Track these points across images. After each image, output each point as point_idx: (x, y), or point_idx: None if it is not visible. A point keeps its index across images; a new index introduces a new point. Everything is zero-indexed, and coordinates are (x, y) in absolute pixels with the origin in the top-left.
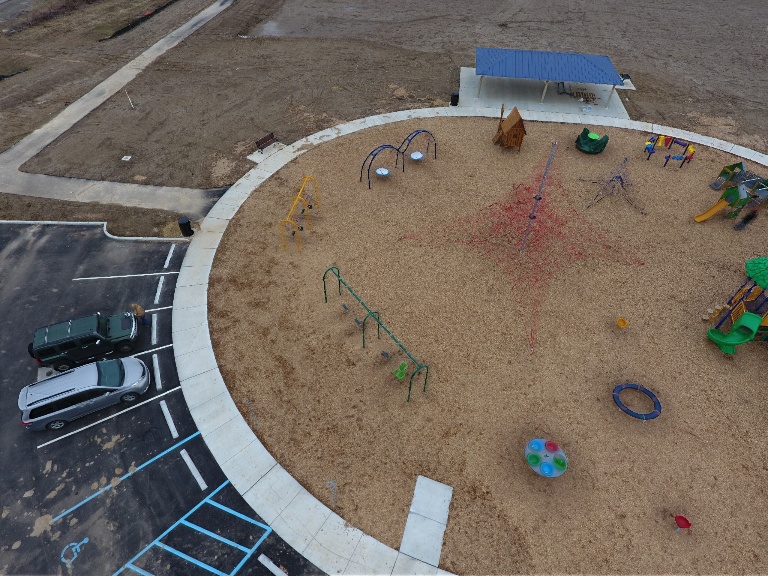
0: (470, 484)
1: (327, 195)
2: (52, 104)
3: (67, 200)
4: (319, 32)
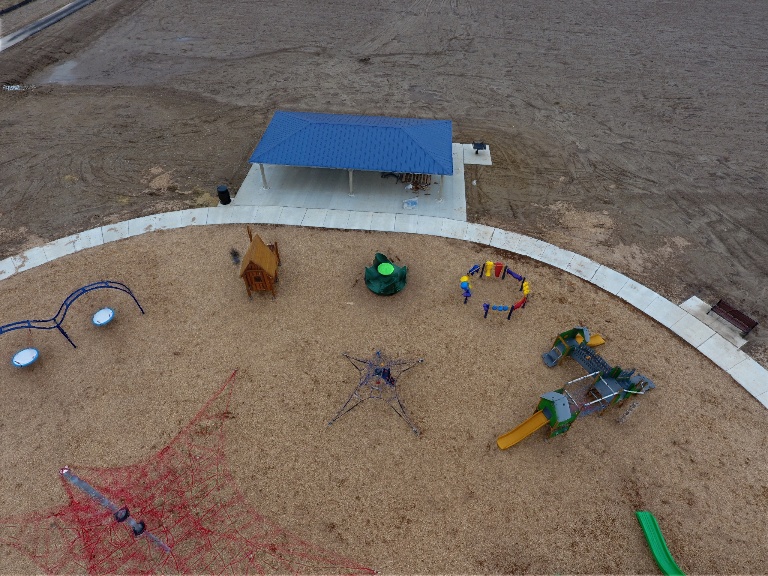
0: None
1: None
2: None
3: None
4: (122, 77)
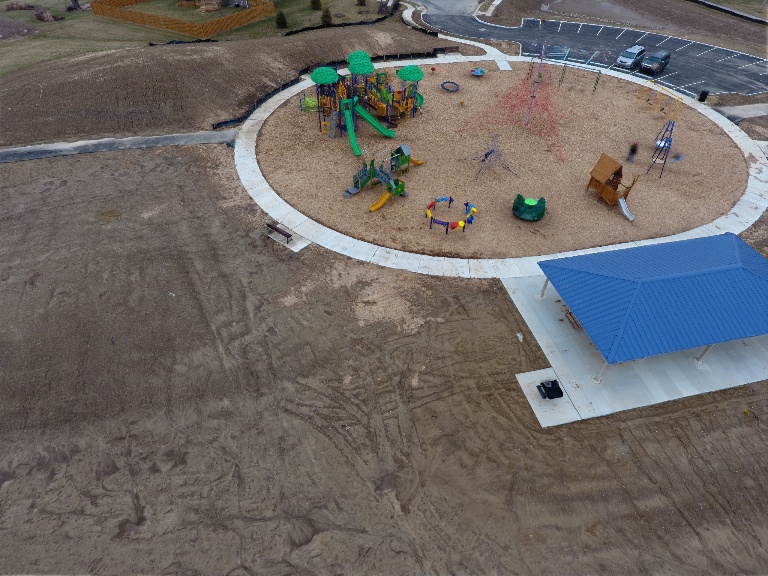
0: (496, 71)
1: None
2: None
3: None
4: None
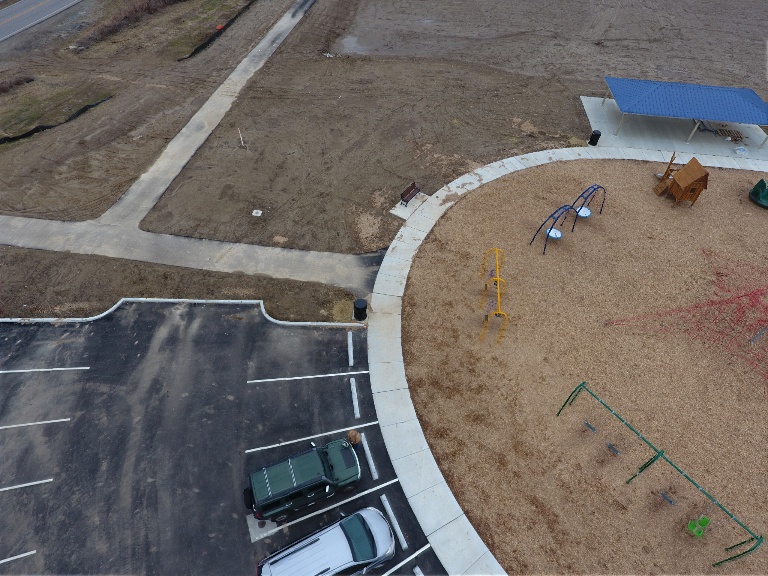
0: None
1: (500, 263)
2: (150, 140)
3: (206, 269)
4: (405, 50)
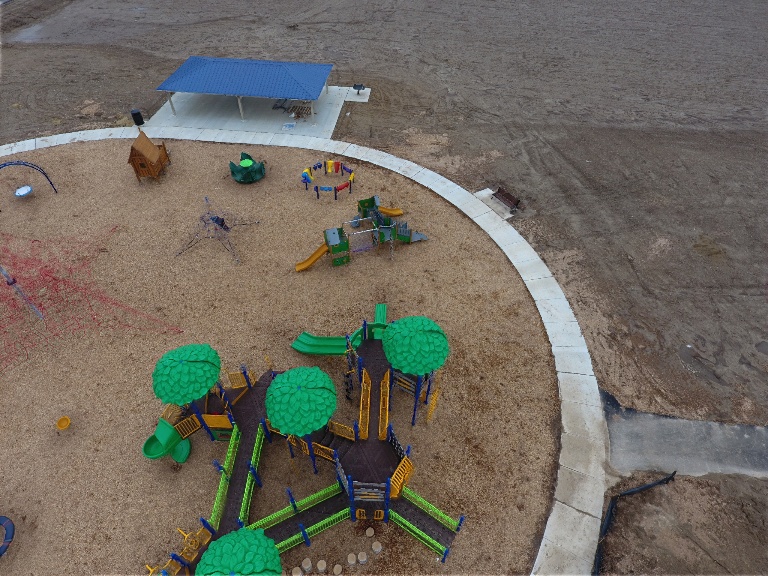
0: None
1: None
2: None
3: None
4: (79, 37)
